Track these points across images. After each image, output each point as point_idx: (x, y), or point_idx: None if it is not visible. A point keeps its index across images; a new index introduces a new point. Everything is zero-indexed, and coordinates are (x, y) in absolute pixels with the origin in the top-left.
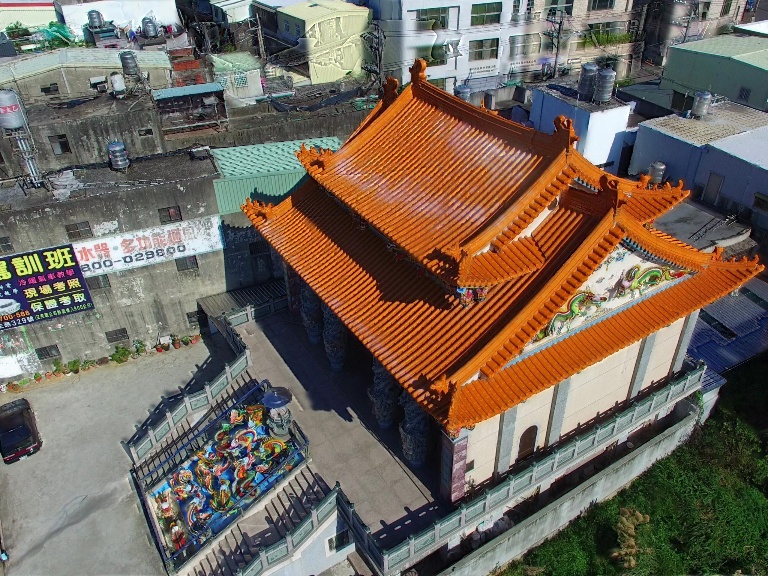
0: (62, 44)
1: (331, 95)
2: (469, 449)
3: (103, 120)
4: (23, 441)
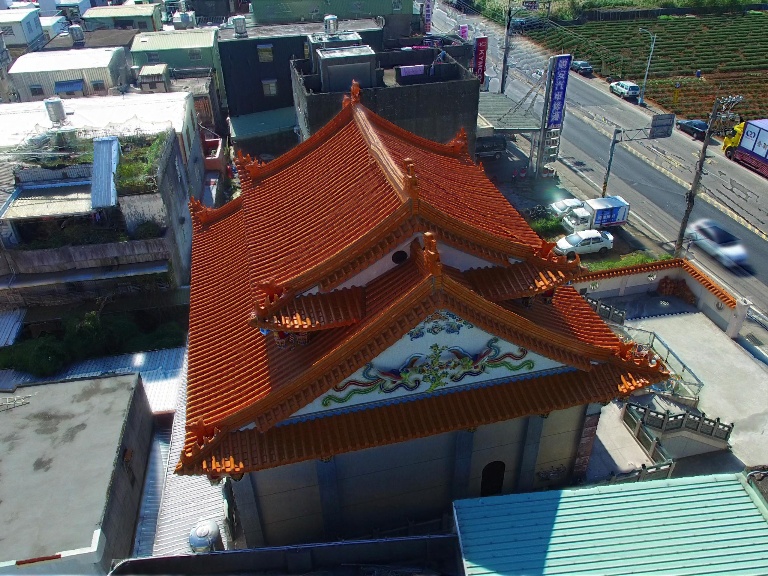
0: None
1: None
2: None
3: None
4: None
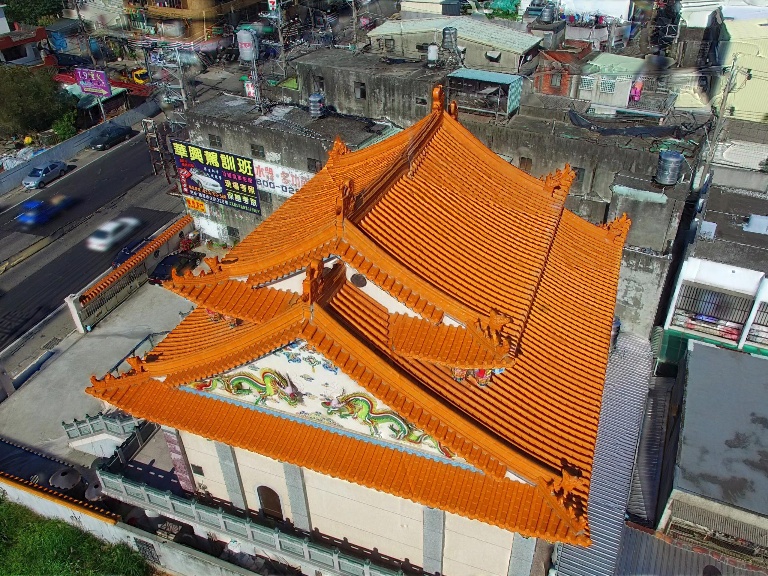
0: (504, 14)
1: (639, 125)
2: (191, 451)
3: (393, 80)
4: (162, 274)
